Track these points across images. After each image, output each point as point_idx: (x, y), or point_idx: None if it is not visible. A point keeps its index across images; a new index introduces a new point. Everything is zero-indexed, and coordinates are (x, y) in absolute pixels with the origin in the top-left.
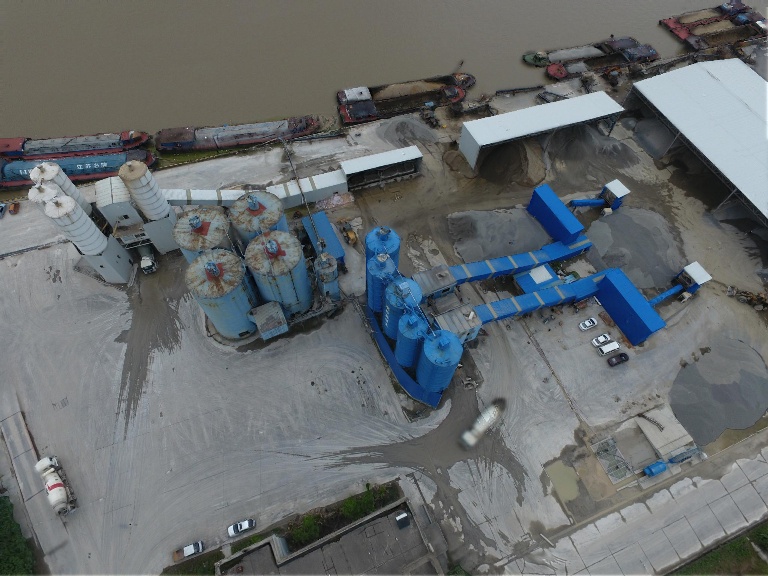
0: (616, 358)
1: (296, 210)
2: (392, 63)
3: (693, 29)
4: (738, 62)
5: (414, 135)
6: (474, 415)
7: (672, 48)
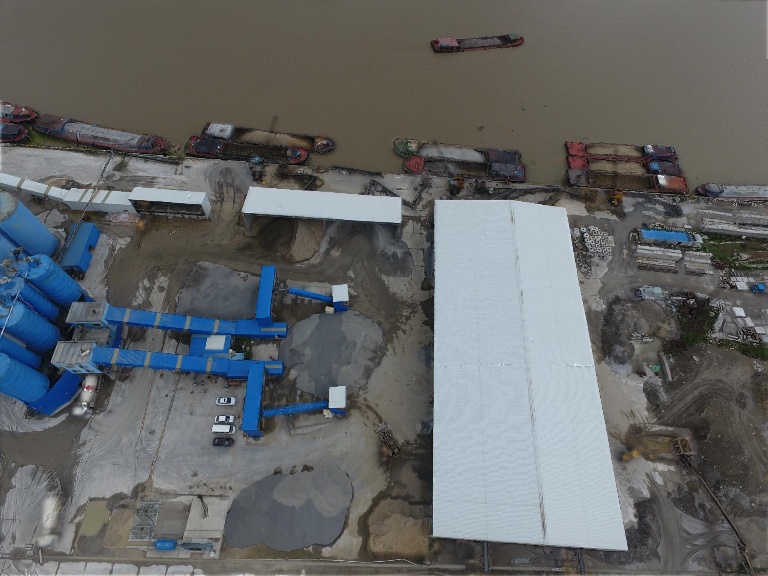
0: (219, 440)
1: (89, 214)
2: (276, 111)
3: (593, 162)
4: (561, 212)
5: (233, 182)
6: (74, 434)
7: (559, 174)
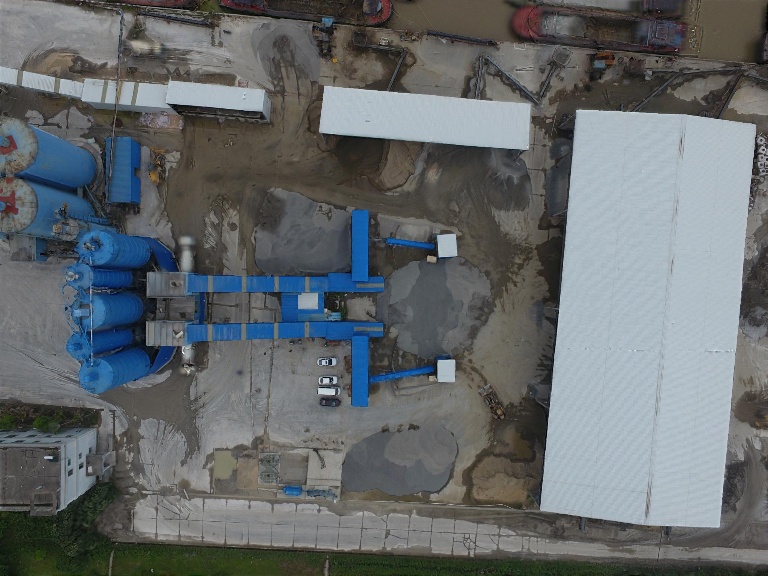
0: (326, 402)
1: (118, 115)
2: None
3: None
4: (749, 132)
5: (293, 59)
6: (184, 391)
7: (747, 35)
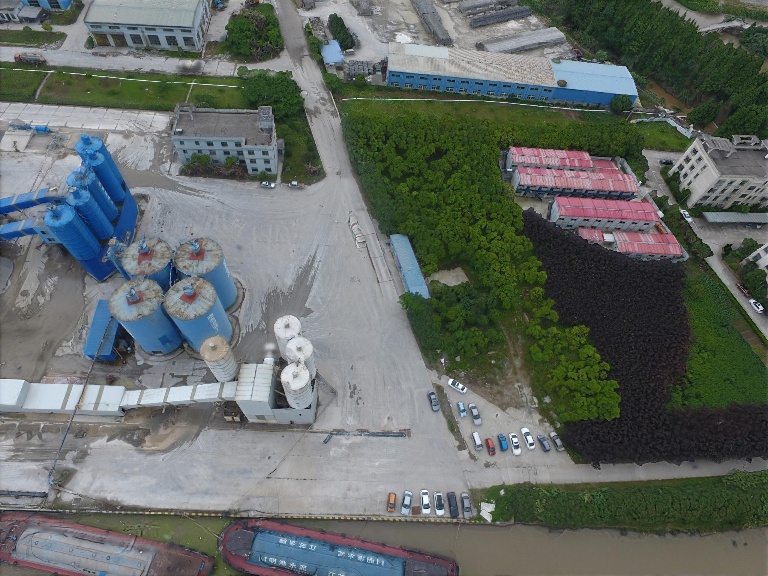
0: None
1: None
2: None
3: None
4: None
5: None
6: None
7: None
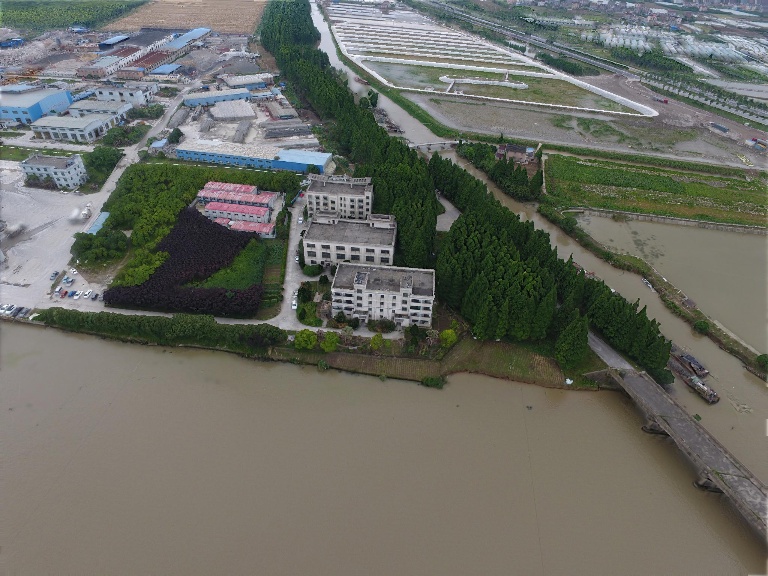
0: None
1: None
2: None
3: None
4: None
5: None
6: None
7: None
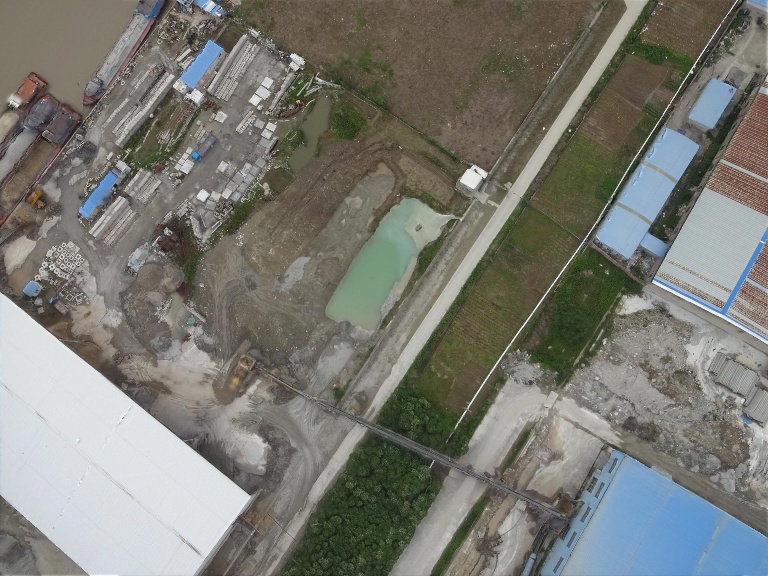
0: None
1: None
2: None
3: None
4: None
5: None
6: None
7: None
